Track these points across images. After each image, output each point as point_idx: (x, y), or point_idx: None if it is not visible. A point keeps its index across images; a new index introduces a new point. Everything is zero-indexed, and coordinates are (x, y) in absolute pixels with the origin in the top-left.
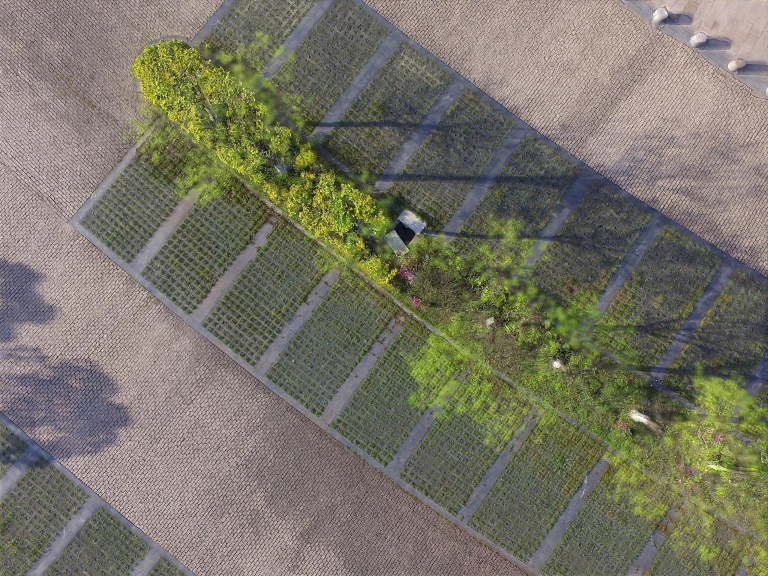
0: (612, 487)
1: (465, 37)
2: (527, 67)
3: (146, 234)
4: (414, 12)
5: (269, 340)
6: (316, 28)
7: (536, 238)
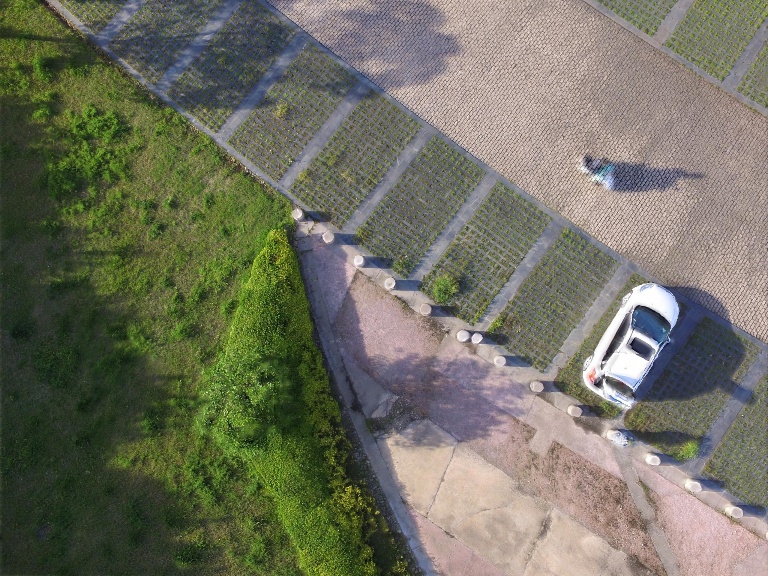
0: None
1: None
2: None
3: None
4: None
5: None
6: None
7: None
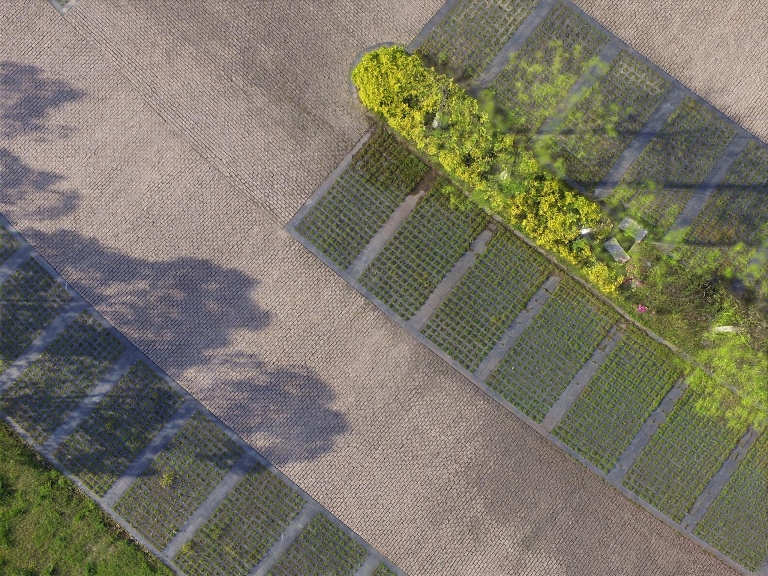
0: None
1: (685, 45)
2: (749, 76)
3: (363, 240)
4: (633, 20)
5: (489, 347)
6: (534, 36)
7: (759, 247)
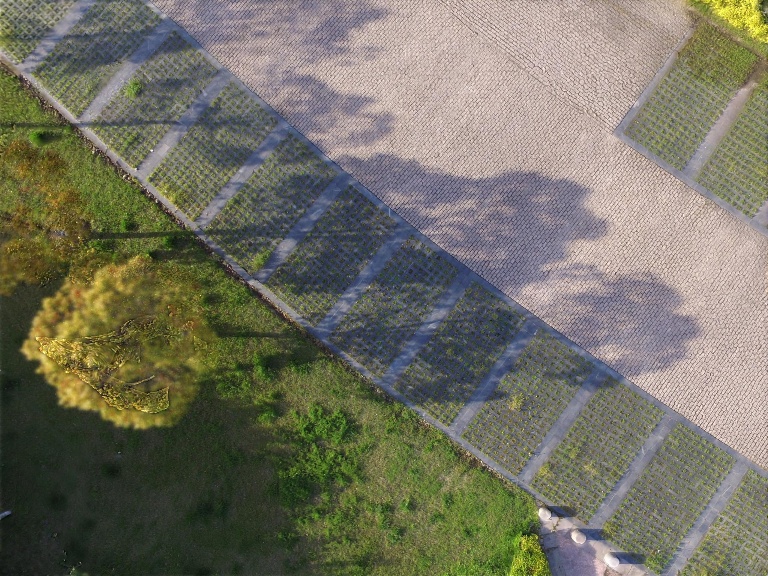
0: None
1: None
2: None
3: (698, 139)
4: None
5: None
6: None
7: None
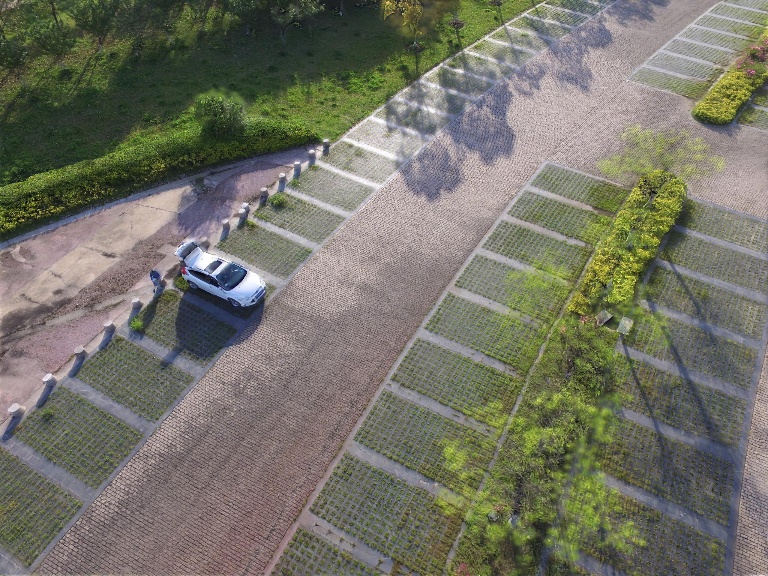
0: (435, 510)
1: None
2: None
3: (552, 190)
4: None
5: (502, 253)
6: (743, 254)
7: (654, 418)
